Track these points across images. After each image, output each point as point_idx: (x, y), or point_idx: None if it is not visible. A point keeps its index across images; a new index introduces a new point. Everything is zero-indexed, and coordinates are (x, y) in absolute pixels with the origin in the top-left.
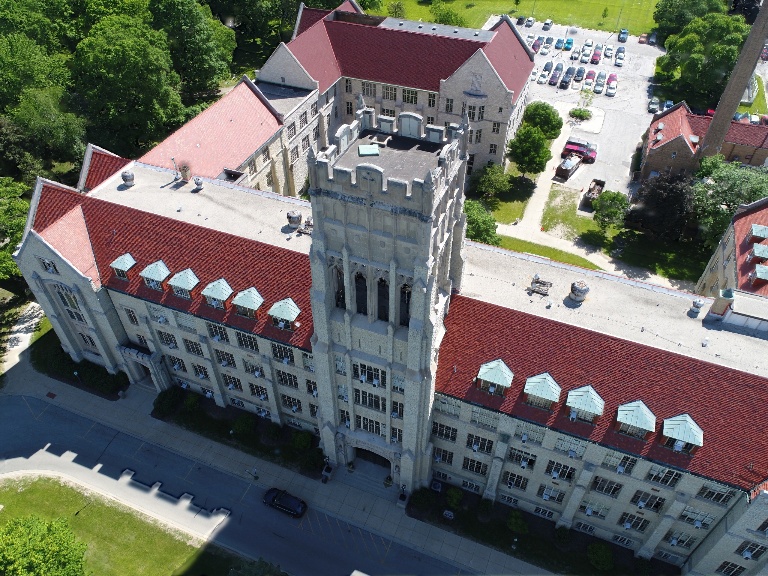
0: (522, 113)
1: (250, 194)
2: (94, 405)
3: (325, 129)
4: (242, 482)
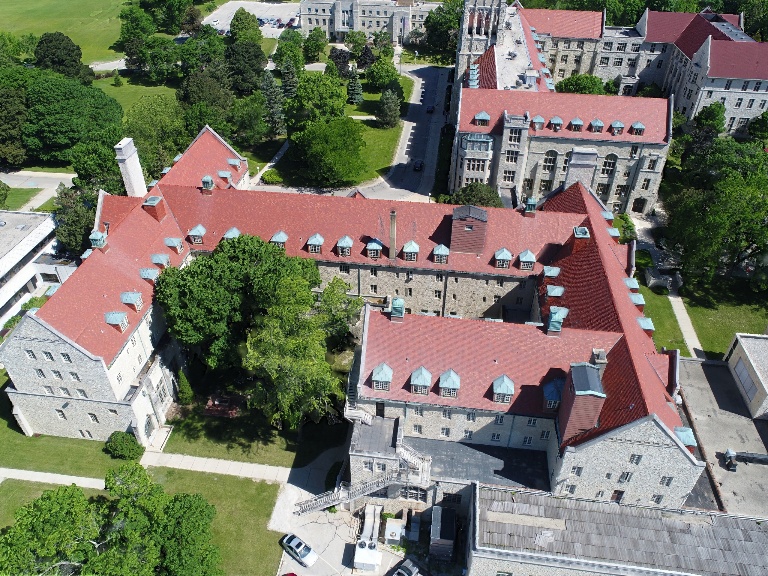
0: (758, 113)
1: (518, 21)
2: (444, 80)
3: (639, 64)
4: (433, 104)
